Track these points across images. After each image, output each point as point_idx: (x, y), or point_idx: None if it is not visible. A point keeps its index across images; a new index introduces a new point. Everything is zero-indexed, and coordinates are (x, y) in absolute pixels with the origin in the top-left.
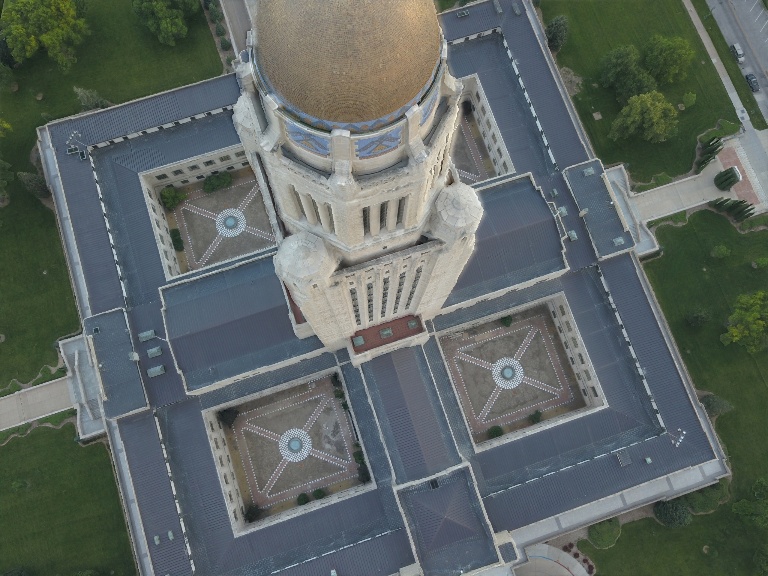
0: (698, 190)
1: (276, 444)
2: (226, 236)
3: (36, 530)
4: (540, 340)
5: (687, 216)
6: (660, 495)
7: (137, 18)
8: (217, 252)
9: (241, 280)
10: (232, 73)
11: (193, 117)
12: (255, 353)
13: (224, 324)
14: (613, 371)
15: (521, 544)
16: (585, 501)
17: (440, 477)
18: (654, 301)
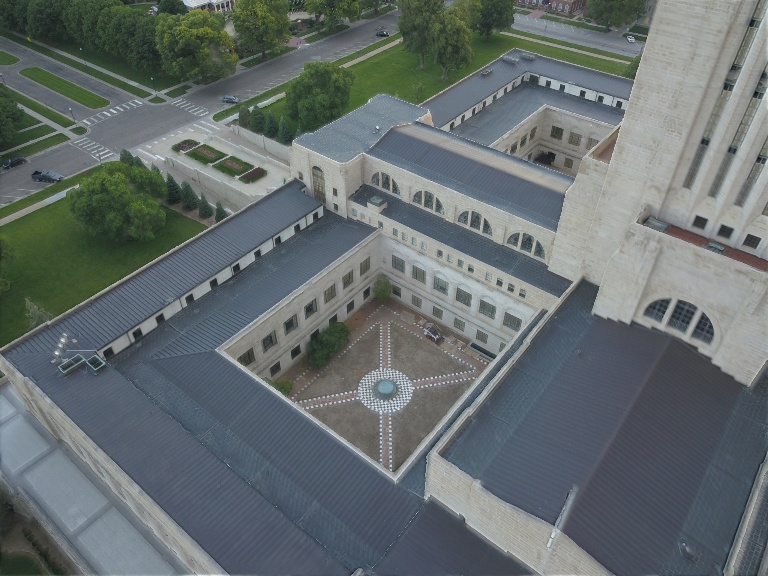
0: None
1: None
2: (393, 411)
3: None
4: None
5: None
6: None
7: (74, 246)
8: (398, 441)
9: (555, 360)
10: (283, 185)
11: (258, 251)
12: (715, 458)
13: (619, 431)
14: None
15: None
16: None
17: None
18: None
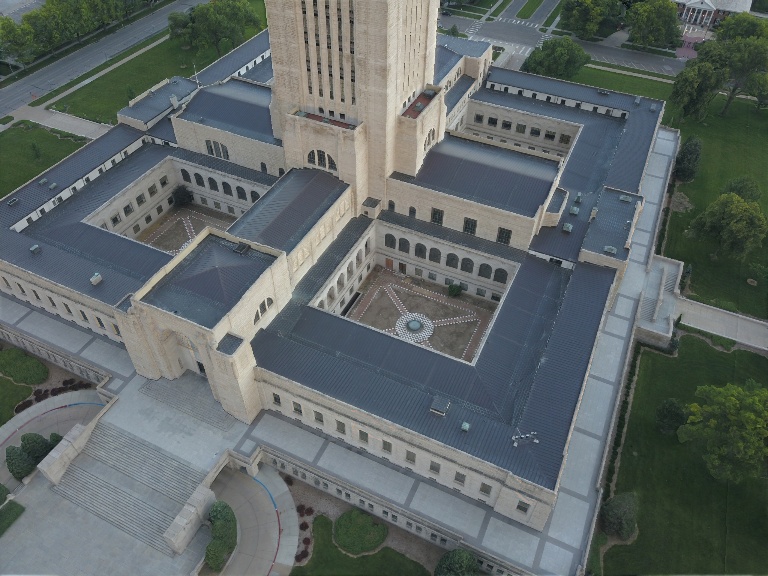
0: (766, 337)
1: (187, 239)
2: None
3: (6, 181)
4: (472, 328)
5: (734, 348)
6: (458, 533)
7: None
8: None
9: None
10: None
11: None
12: (237, 127)
13: (240, 101)
14: (510, 348)
15: (262, 440)
16: (357, 406)
17: (252, 252)
18: (624, 364)
